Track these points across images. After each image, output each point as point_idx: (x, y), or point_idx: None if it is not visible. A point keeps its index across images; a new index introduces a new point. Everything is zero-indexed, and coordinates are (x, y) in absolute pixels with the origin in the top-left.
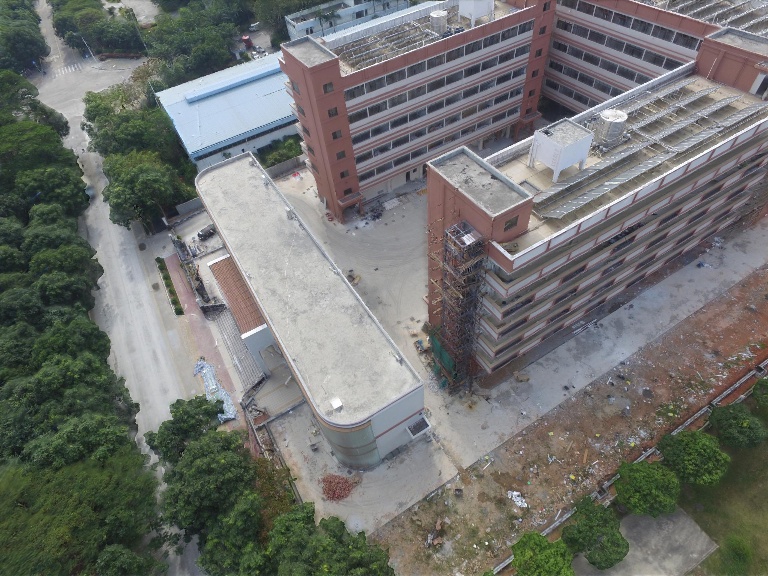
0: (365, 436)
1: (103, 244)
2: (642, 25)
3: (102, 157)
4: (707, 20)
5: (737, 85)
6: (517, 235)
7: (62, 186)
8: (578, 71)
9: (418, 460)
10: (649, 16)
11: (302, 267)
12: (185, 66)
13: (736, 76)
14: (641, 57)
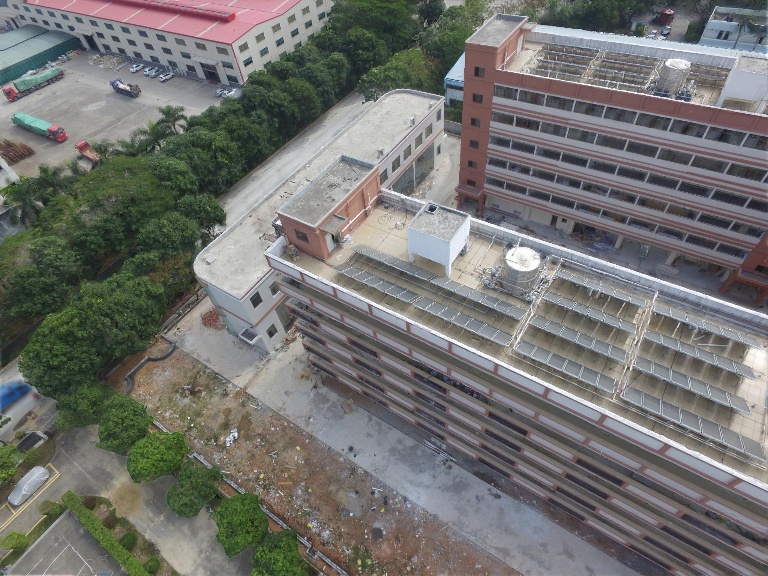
0: (209, 295)
1: (356, 105)
2: None
3: (420, 48)
4: None
5: None
6: (314, 255)
7: (367, 50)
8: None
9: (244, 358)
10: None
11: None
12: (577, 12)
13: None
14: None
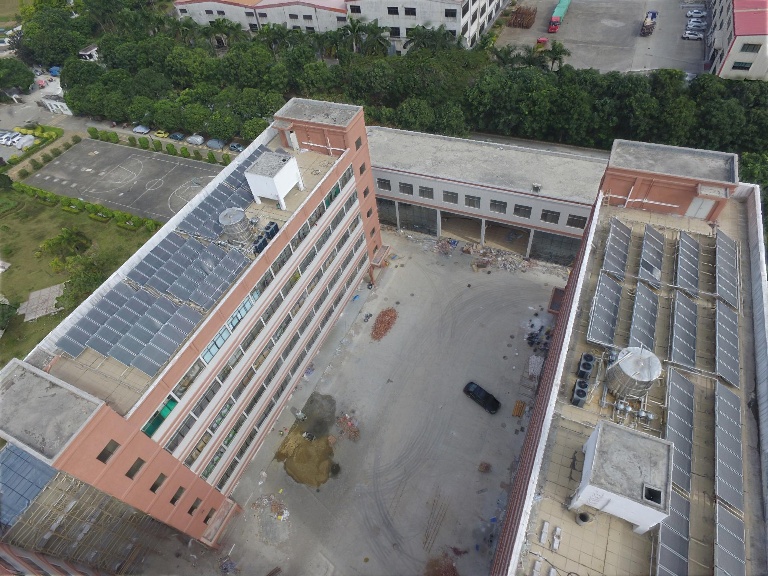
0: None
1: None
2: None
3: None
4: None
5: None
6: None
7: None
8: None
9: None
10: None
11: (471, 169)
12: None
13: None
14: None
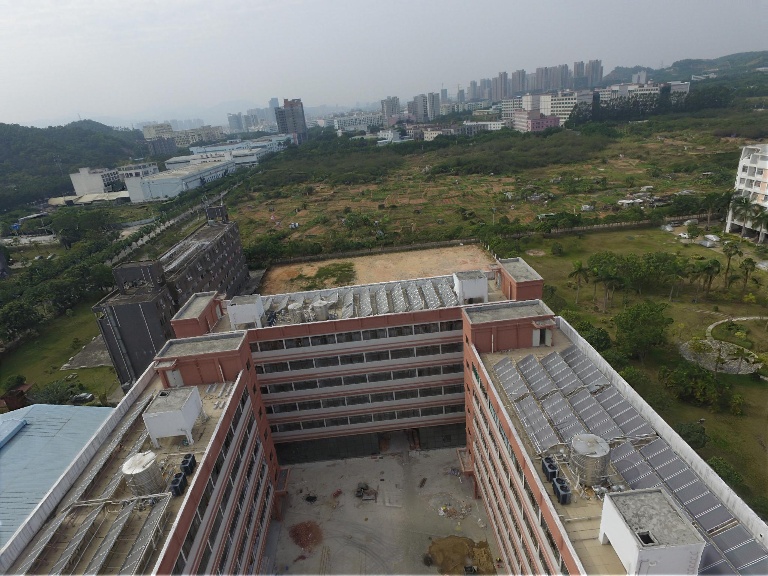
0: None
1: None
2: (348, 336)
3: None
4: (405, 310)
5: (520, 346)
6: None
7: None
8: (295, 402)
9: None
10: (352, 327)
11: None
12: None
13: (516, 340)
14: (363, 360)
